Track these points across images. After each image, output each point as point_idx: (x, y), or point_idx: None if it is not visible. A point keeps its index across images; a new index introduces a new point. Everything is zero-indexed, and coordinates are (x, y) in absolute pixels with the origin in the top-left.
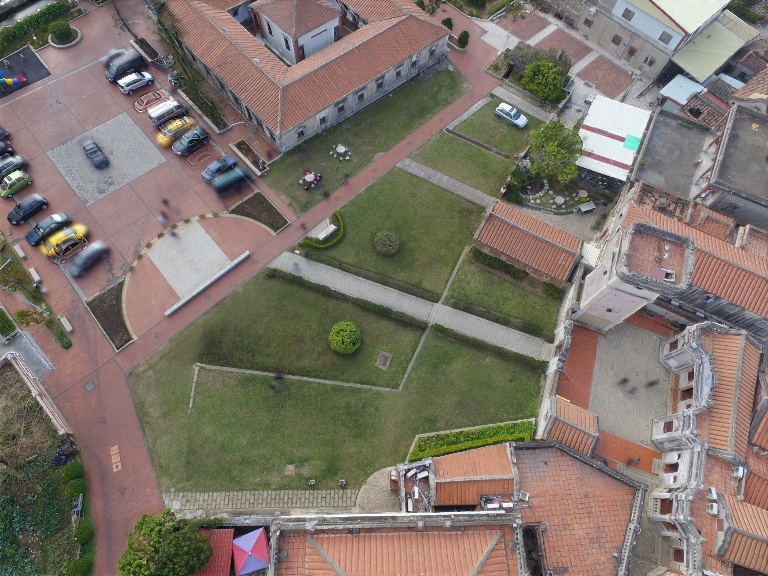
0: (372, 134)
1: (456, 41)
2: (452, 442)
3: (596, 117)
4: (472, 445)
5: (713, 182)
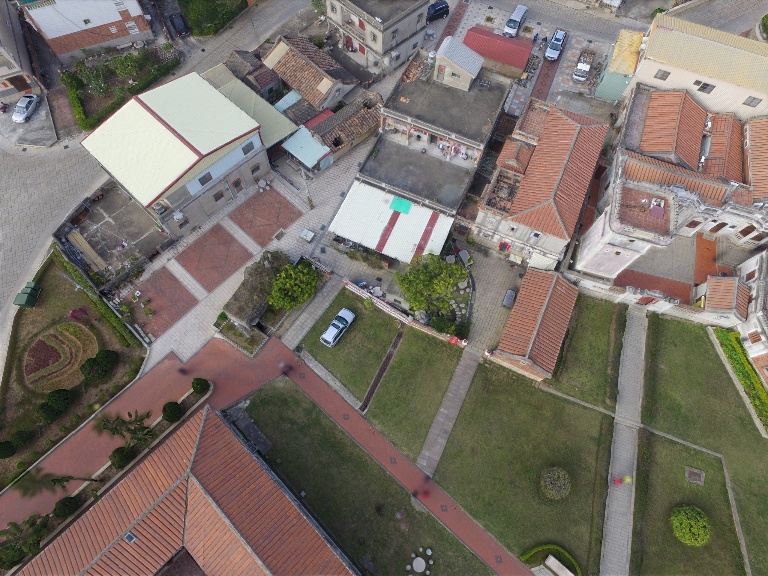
0: (378, 518)
1: (192, 397)
2: (759, 402)
3: (364, 235)
4: (759, 383)
5: (483, 147)
